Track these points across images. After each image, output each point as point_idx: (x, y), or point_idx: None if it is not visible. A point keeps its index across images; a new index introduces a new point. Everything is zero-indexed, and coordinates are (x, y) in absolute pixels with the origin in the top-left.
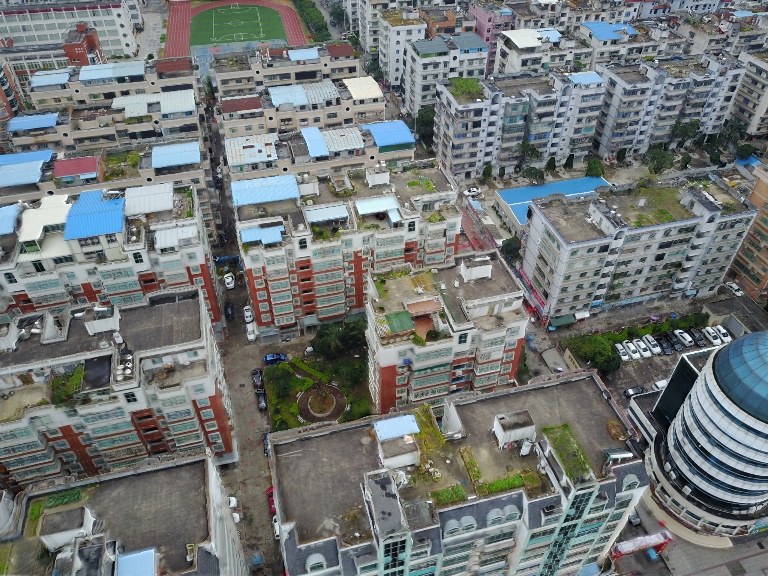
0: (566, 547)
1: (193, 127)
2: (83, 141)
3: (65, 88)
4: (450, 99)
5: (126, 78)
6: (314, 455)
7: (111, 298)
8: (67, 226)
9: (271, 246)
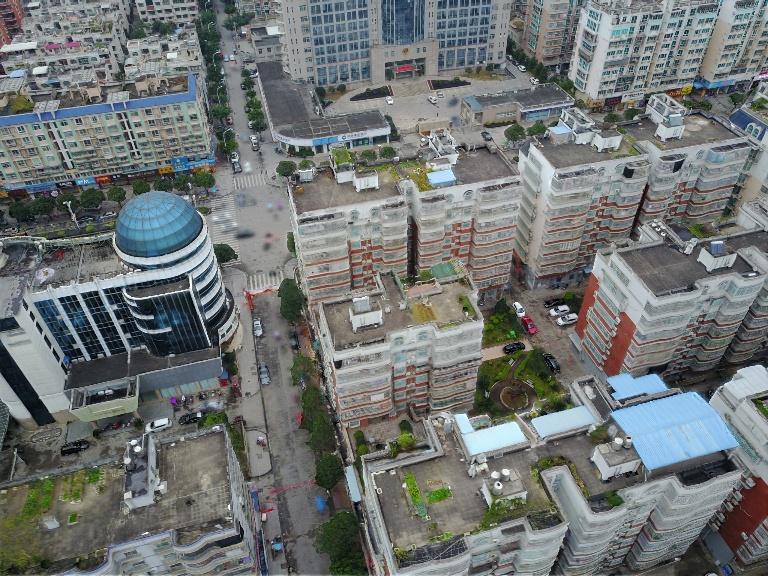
0: None
1: None
2: None
3: None
4: None
5: None
6: (490, 176)
7: None
8: None
9: None
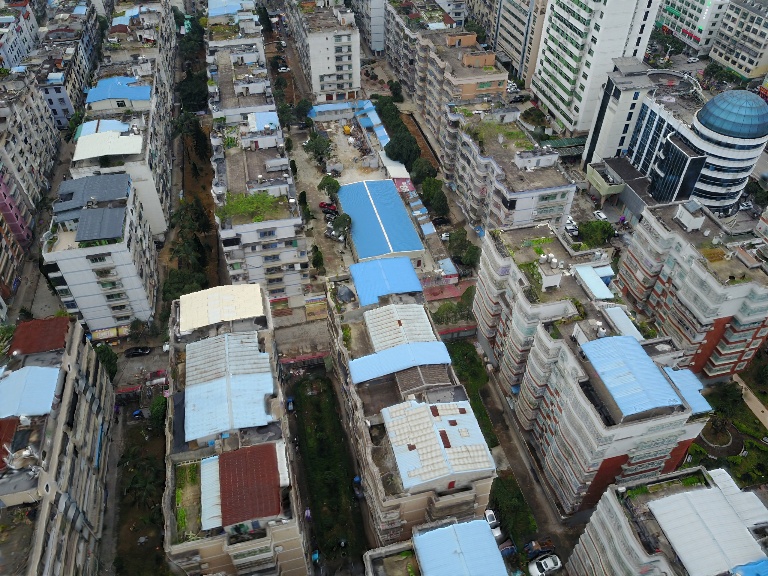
0: None
1: None
2: None
3: None
4: (270, 227)
5: None
6: None
7: None
8: None
9: None
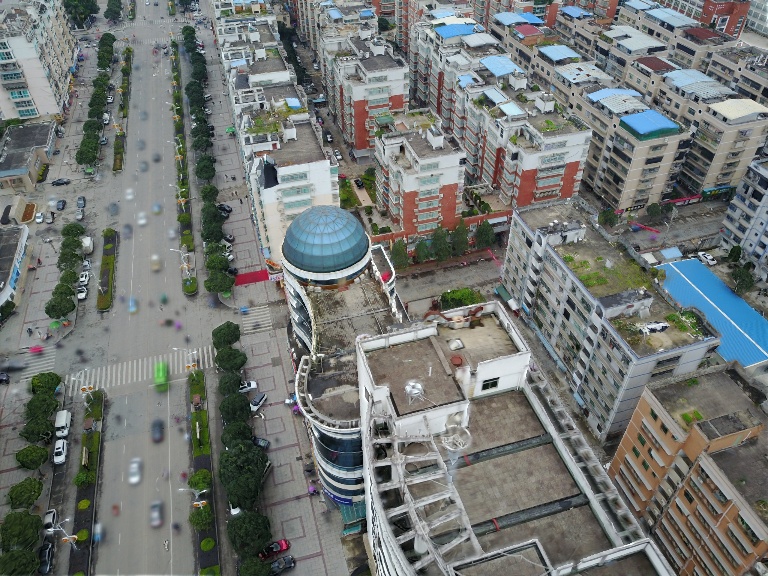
0: (251, 192)
1: (623, 62)
2: (579, 36)
3: (637, 13)
4: None
5: (666, 24)
6: (287, 93)
7: (431, 75)
8: (444, 26)
9: (461, 88)
